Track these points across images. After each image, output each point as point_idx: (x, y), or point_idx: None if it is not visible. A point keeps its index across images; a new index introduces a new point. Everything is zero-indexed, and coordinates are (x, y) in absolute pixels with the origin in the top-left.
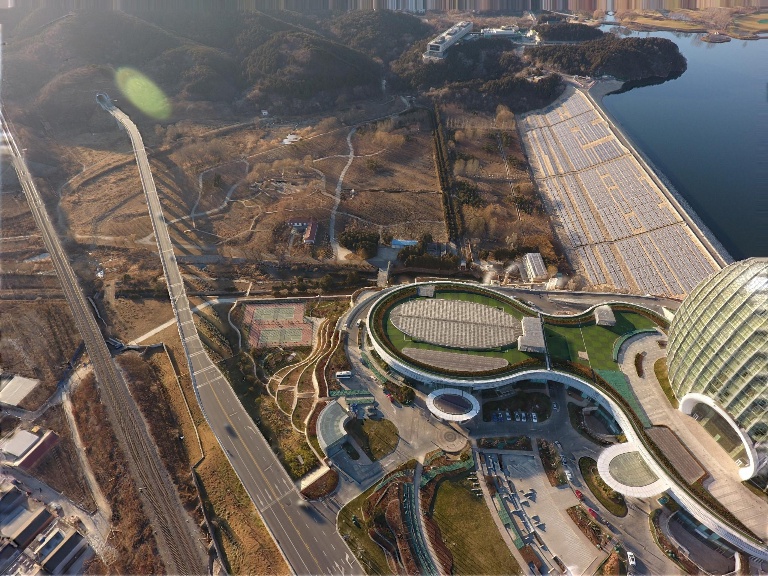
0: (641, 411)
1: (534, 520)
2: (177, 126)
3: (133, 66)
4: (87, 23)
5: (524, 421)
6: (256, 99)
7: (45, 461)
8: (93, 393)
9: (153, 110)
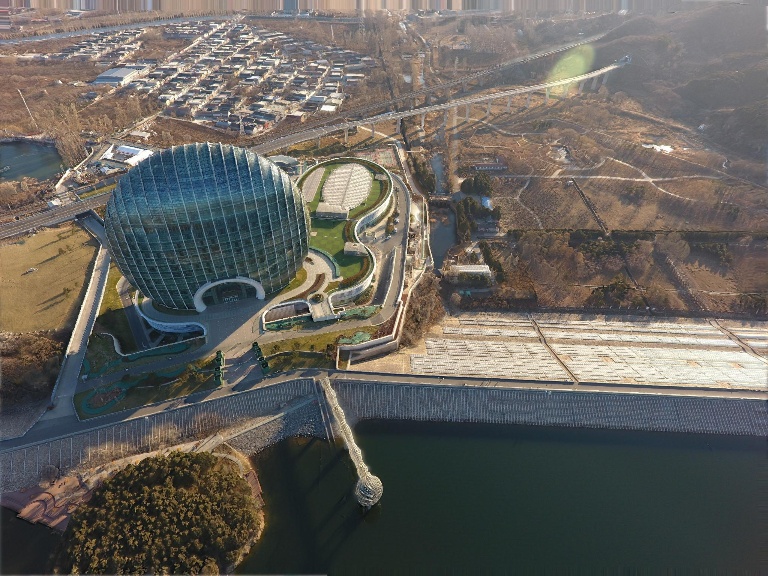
0: None
1: None
2: (615, 94)
3: (703, 54)
4: (738, 12)
5: None
6: (717, 114)
7: (289, 119)
8: (320, 118)
9: (641, 83)
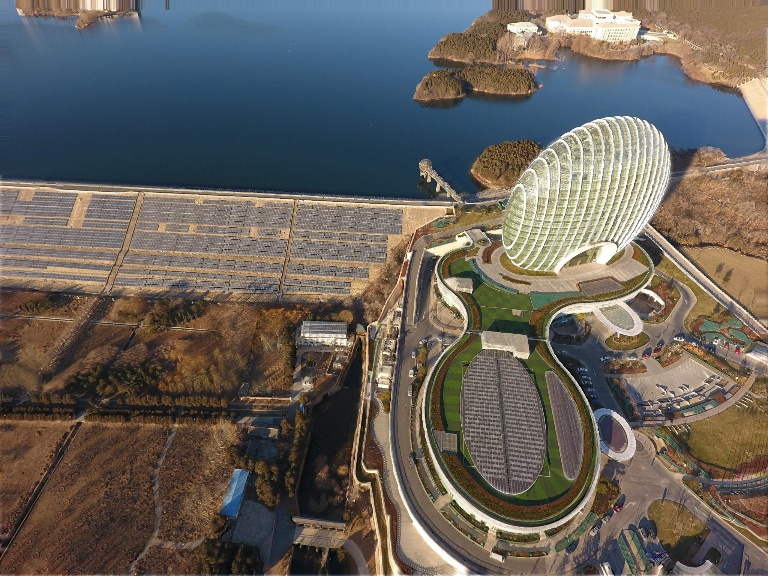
0: (569, 293)
1: (684, 390)
2: None
3: None
4: None
5: (590, 378)
6: None
7: None
8: None
9: None
